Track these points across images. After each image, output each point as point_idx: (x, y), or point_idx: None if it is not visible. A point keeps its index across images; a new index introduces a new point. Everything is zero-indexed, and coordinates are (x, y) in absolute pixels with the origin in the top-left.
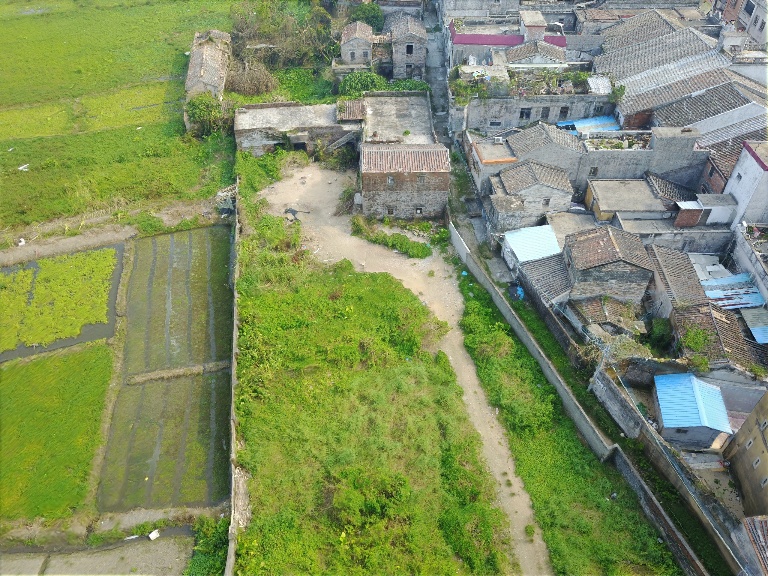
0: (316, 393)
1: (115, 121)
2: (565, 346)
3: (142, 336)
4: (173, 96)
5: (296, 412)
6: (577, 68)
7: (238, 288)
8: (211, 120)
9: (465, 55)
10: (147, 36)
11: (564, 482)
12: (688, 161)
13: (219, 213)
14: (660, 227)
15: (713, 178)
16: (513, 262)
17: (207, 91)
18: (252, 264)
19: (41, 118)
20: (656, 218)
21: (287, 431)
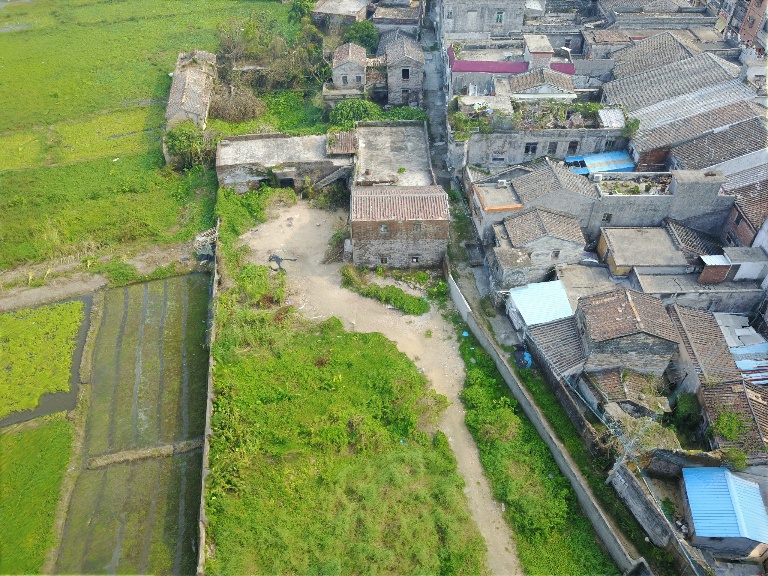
0: (298, 485)
1: (91, 151)
2: (579, 427)
3: (107, 408)
4: (154, 123)
5: (275, 509)
6: (586, 95)
7: (214, 354)
8: (192, 152)
9: (465, 83)
10: (129, 55)
11: None
12: (712, 207)
13: (198, 259)
14: (682, 284)
15: (740, 227)
16: (519, 325)
17: (189, 119)
18: (230, 324)
19: (12, 148)
20: (678, 273)
21: (263, 535)
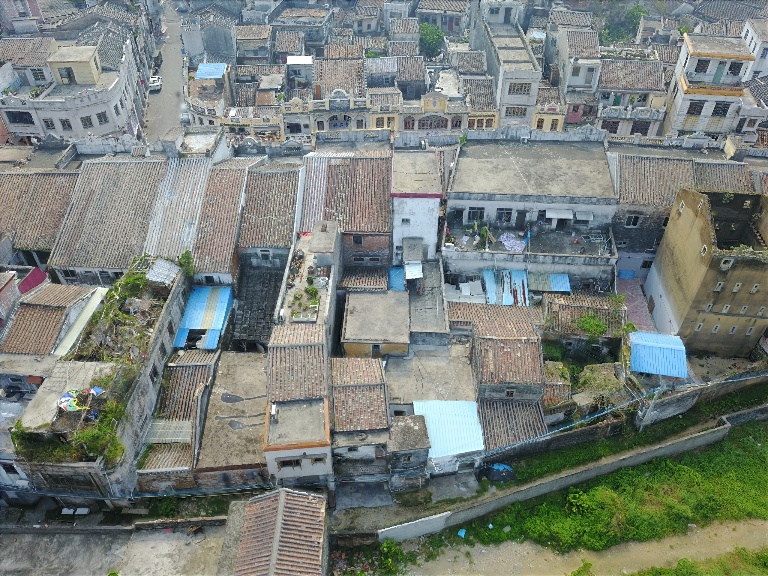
0: None
1: None
2: (592, 436)
3: None
4: None
5: None
6: None
7: None
8: None
9: None
10: None
11: (759, 475)
12: (339, 249)
13: None
14: (423, 306)
15: (366, 243)
16: None
17: None
18: None
19: None
20: None
21: None
